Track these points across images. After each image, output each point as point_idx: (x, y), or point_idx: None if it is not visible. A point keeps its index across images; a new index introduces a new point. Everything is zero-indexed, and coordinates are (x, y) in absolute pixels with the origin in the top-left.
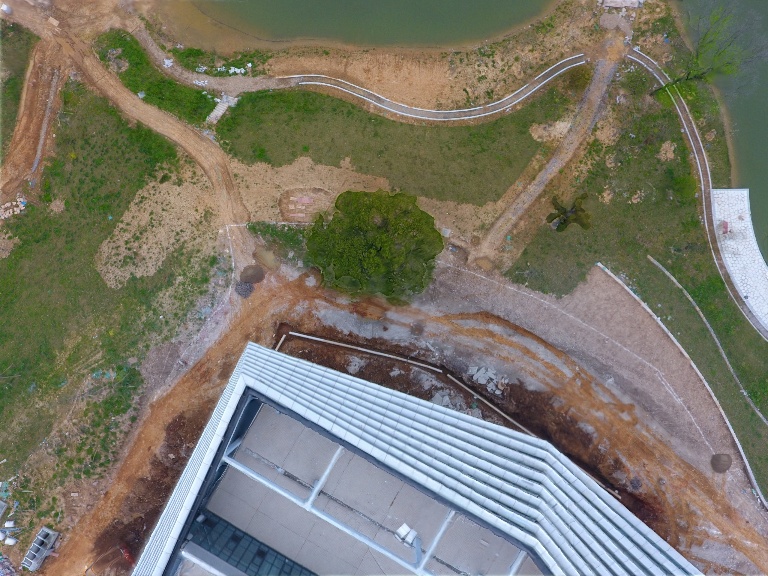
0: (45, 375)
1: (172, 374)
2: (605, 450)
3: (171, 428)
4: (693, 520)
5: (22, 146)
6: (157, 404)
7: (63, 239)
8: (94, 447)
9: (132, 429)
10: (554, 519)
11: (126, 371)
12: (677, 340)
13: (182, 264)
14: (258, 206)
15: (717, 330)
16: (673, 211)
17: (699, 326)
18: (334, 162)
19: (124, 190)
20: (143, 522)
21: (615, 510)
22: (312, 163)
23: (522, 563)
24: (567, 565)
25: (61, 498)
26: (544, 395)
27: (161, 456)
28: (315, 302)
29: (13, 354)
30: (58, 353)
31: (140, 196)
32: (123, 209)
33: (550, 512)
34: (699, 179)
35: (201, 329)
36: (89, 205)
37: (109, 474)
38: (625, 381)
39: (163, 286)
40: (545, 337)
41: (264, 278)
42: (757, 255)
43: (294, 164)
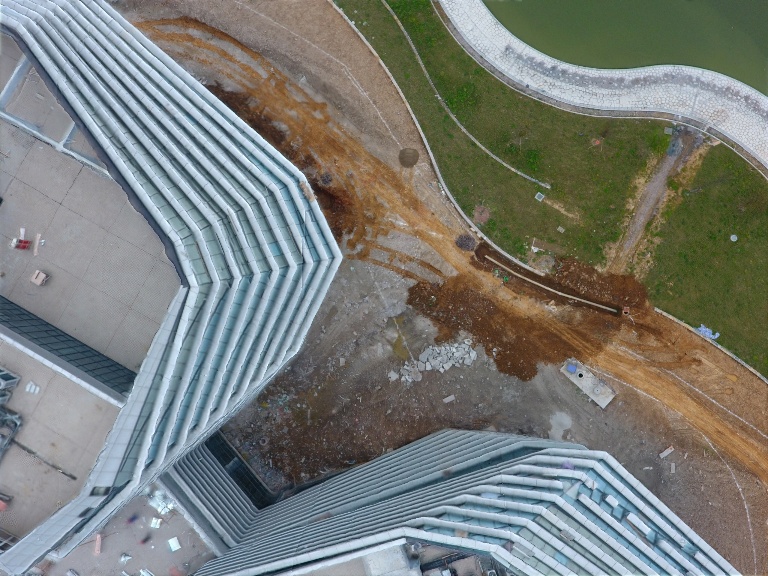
0: None
1: None
2: (297, 147)
3: None
4: (380, 212)
5: None
6: None
7: None
8: None
9: None
10: (60, 27)
11: None
12: (371, 44)
13: None
14: None
15: (417, 40)
16: None
17: (396, 34)
18: None
19: None
20: None
21: (161, 60)
22: None
23: (23, 63)
24: (54, 52)
25: None
26: (240, 96)
27: None
28: None
29: None
30: None
31: None
32: None
33: (56, 20)
34: None
35: None
36: None
37: None
38: (314, 77)
39: None
40: (239, 37)
41: None
42: None
43: None
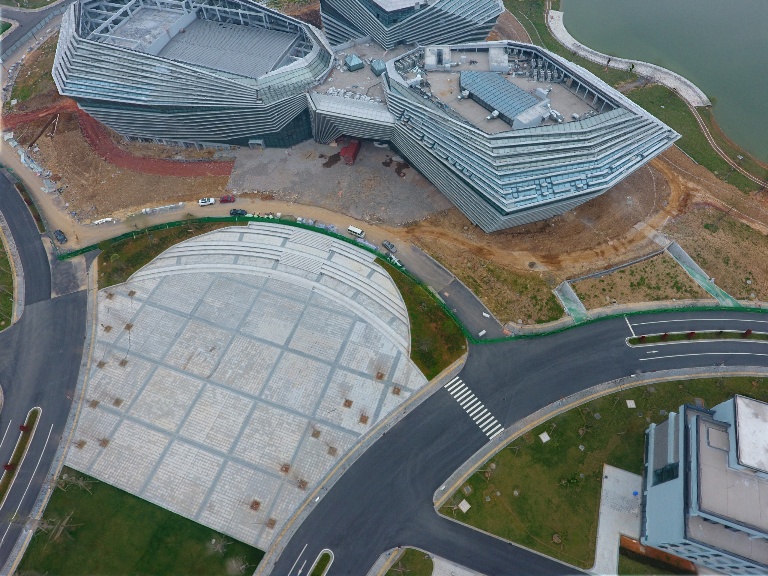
0: None
1: None
2: None
3: None
4: None
5: None
6: None
7: None
8: None
9: None
10: None
11: None
12: None
13: None
14: None
15: None
16: (533, 8)
17: None
18: None
19: None
20: None
21: None
22: None
23: None
24: None
25: (286, 5)
26: None
27: None
28: None
29: None
30: None
31: None
32: None
33: None
34: (547, 7)
35: None
36: None
37: (305, 6)
38: (497, 25)
39: None
40: None
41: None
42: (562, 25)
43: None
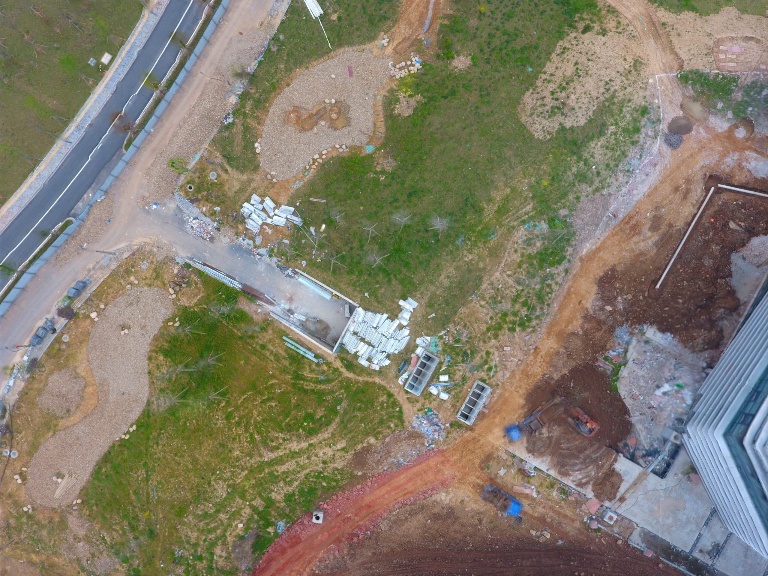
0: (474, 227)
1: (601, 227)
2: None
3: (605, 280)
4: None
5: (417, 4)
6: (586, 257)
7: (476, 93)
8: (529, 299)
9: (563, 282)
10: None
11: (560, 222)
12: None
13: (614, 113)
14: (692, 54)
15: None
16: None
17: None
18: (760, 12)
19: (542, 42)
20: (571, 378)
21: None
22: (739, 12)
23: None
24: None
25: (495, 352)
26: None
27: (593, 310)
28: (745, 153)
29: (436, 208)
30: (486, 205)
31: (562, 47)
32: (544, 60)
33: None
34: None
35: (629, 181)
36: (503, 58)
37: (540, 328)
38: None
39: (595, 136)
40: None
41: (692, 129)
42: None
43: (721, 13)
